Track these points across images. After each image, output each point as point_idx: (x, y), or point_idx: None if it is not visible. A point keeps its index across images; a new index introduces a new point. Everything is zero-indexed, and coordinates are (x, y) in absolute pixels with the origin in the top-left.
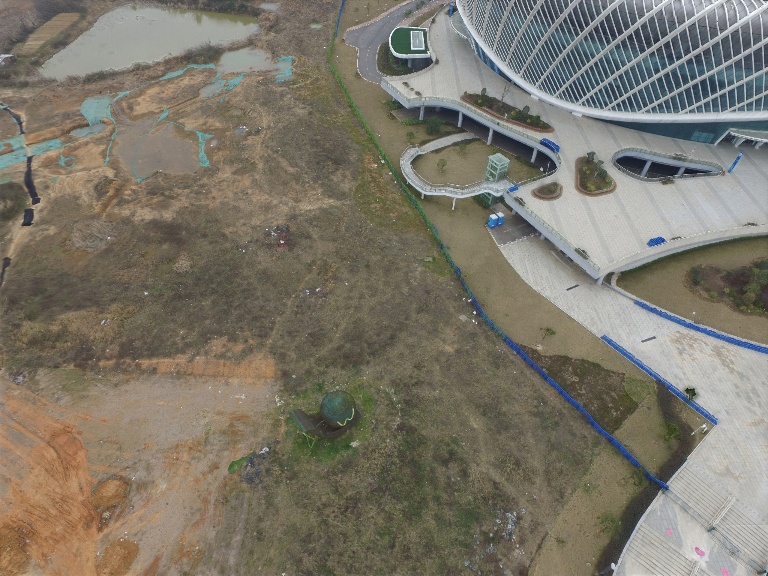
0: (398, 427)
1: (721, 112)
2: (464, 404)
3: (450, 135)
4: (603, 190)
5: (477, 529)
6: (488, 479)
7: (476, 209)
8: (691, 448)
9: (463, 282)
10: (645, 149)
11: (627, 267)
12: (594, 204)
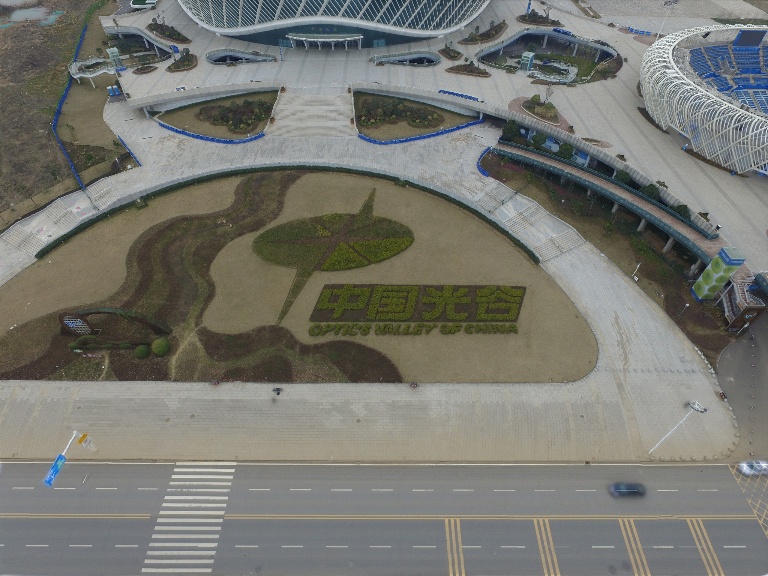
0: None
1: (273, 21)
2: (5, 163)
3: (137, 53)
4: (180, 69)
5: None
6: None
7: None
8: (114, 174)
9: (55, 115)
10: (235, 49)
11: (167, 107)
12: (168, 76)
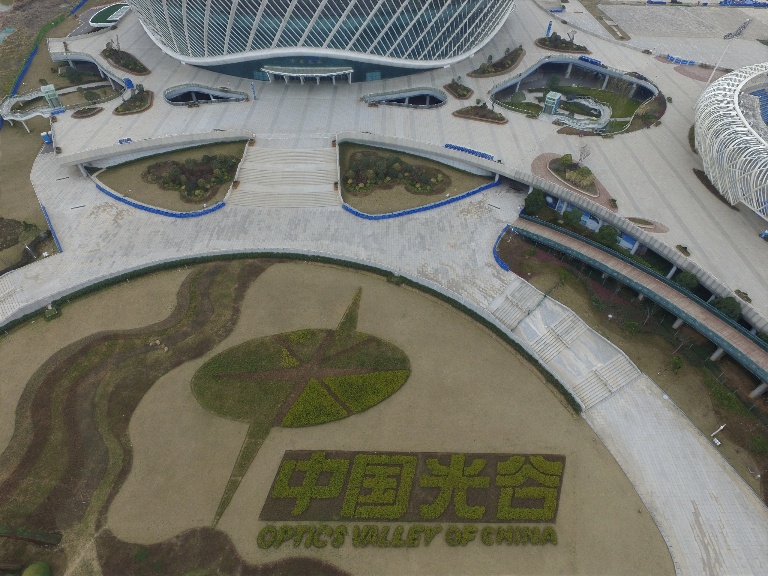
0: None
1: (244, 51)
2: None
3: (89, 83)
4: (130, 111)
5: None
6: None
7: None
8: (24, 265)
9: None
10: (200, 84)
11: (109, 163)
12: (114, 121)
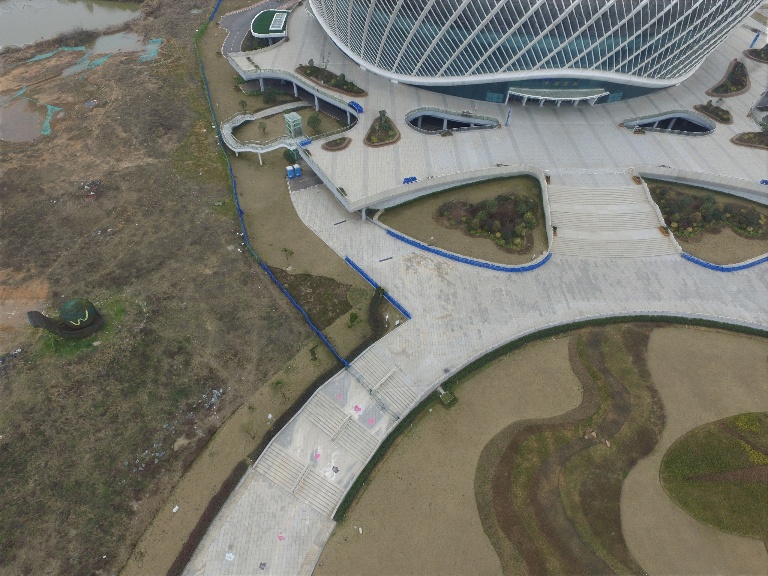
0: (140, 330)
1: (496, 73)
2: (205, 312)
3: (285, 104)
4: (385, 142)
5: (184, 402)
6: (206, 366)
7: (283, 164)
8: (381, 336)
9: (240, 220)
10: (438, 108)
11: (388, 204)
12: (373, 153)
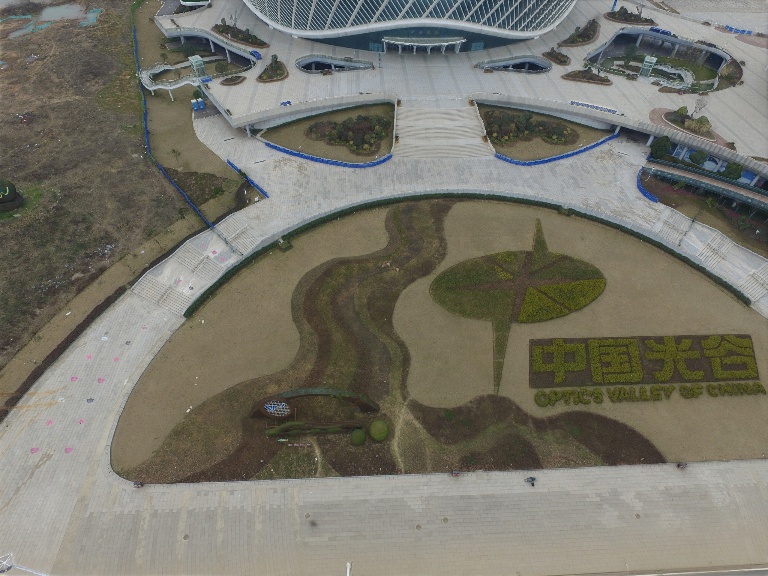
0: (53, 207)
1: (369, 23)
2: (107, 197)
3: (203, 58)
4: (273, 79)
5: (83, 252)
6: (104, 231)
7: None
8: (242, 208)
9: (145, 136)
10: (325, 55)
11: (270, 124)
12: (262, 87)
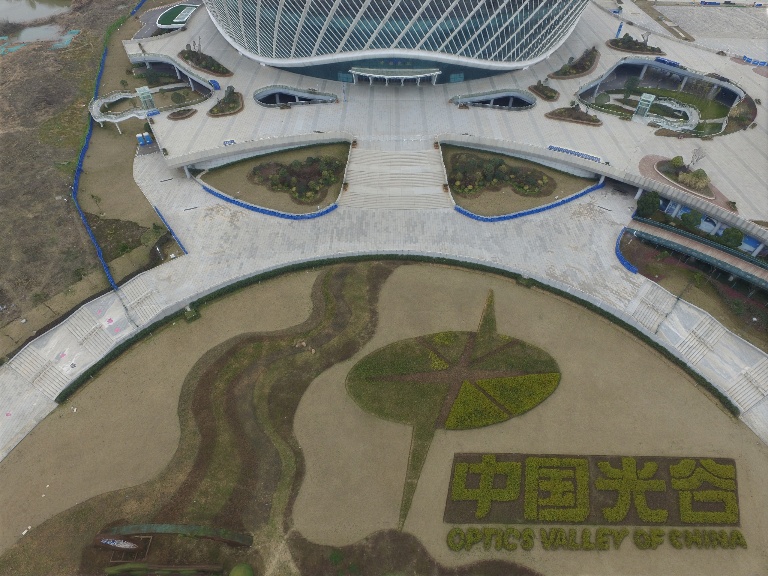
0: None
1: (334, 53)
2: (14, 247)
3: (167, 85)
4: (225, 113)
5: None
6: None
7: None
8: (154, 266)
9: None
10: (287, 86)
11: (212, 165)
12: (210, 122)
